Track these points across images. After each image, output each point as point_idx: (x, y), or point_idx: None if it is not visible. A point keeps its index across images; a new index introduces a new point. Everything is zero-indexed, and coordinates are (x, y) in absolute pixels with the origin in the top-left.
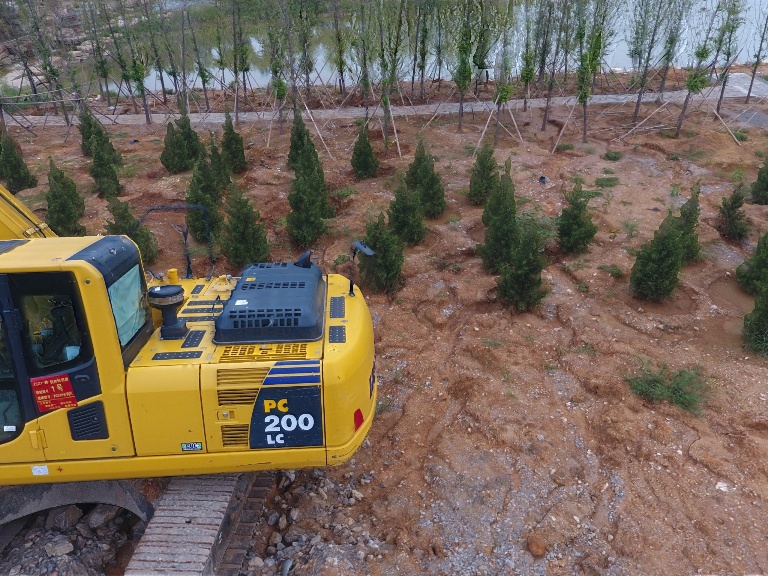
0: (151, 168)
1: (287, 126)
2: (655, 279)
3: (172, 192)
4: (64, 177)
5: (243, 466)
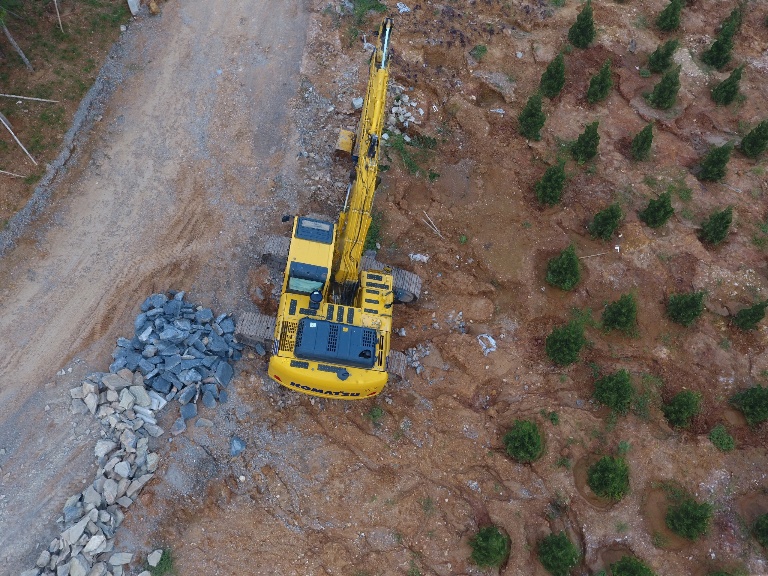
0: None
1: None
2: None
3: (703, 283)
4: (666, 203)
5: None
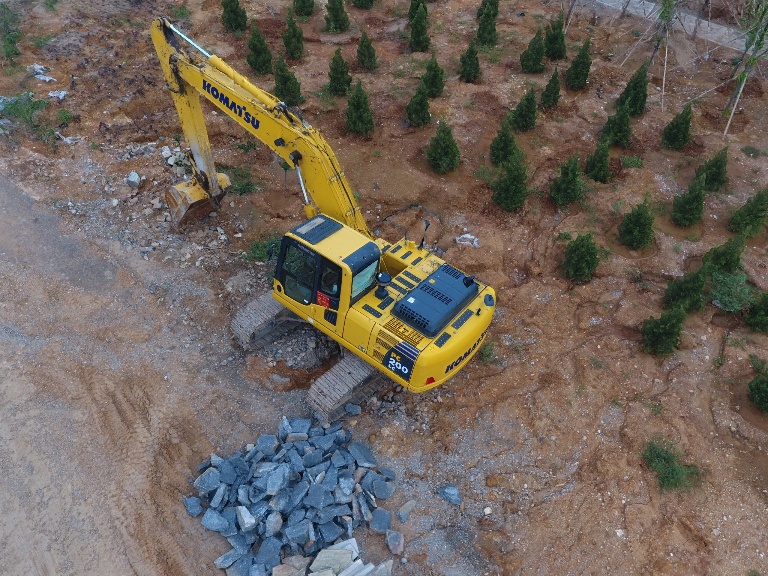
0: (513, 57)
1: None
2: (762, 396)
3: (507, 99)
4: (437, 67)
5: (377, 367)
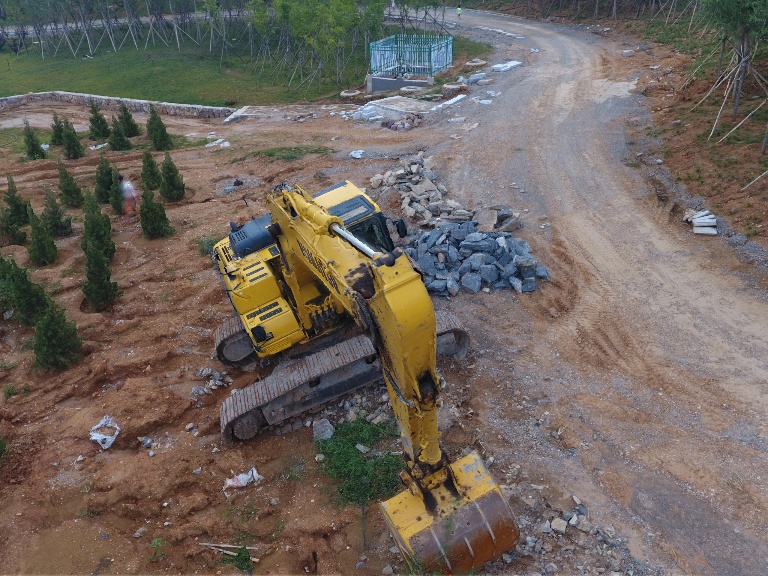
0: None
1: None
2: None
3: None
4: None
5: None
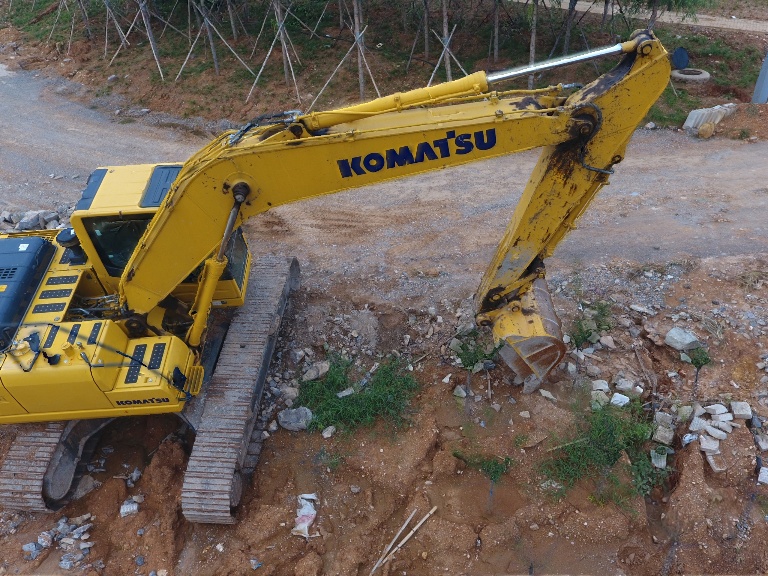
0: None
1: None
2: None
3: None
4: None
5: None
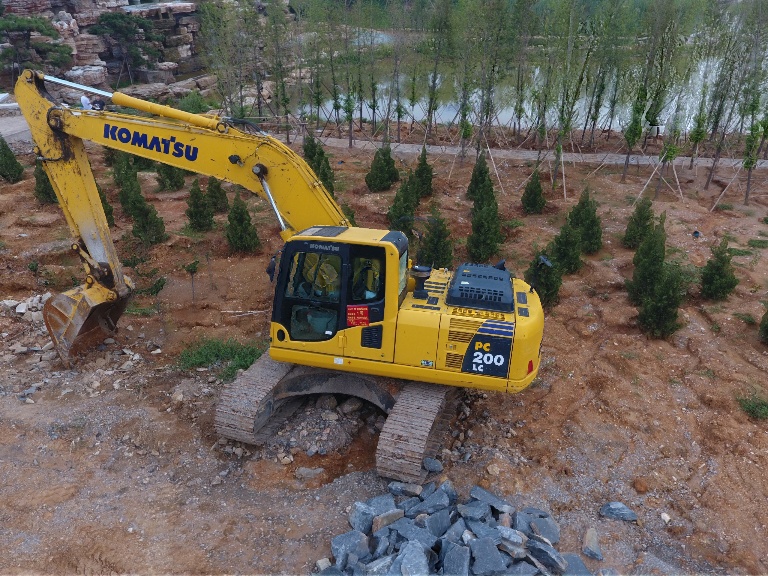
0: (356, 185)
1: (466, 161)
2: None
3: (374, 207)
4: None
5: (455, 381)
